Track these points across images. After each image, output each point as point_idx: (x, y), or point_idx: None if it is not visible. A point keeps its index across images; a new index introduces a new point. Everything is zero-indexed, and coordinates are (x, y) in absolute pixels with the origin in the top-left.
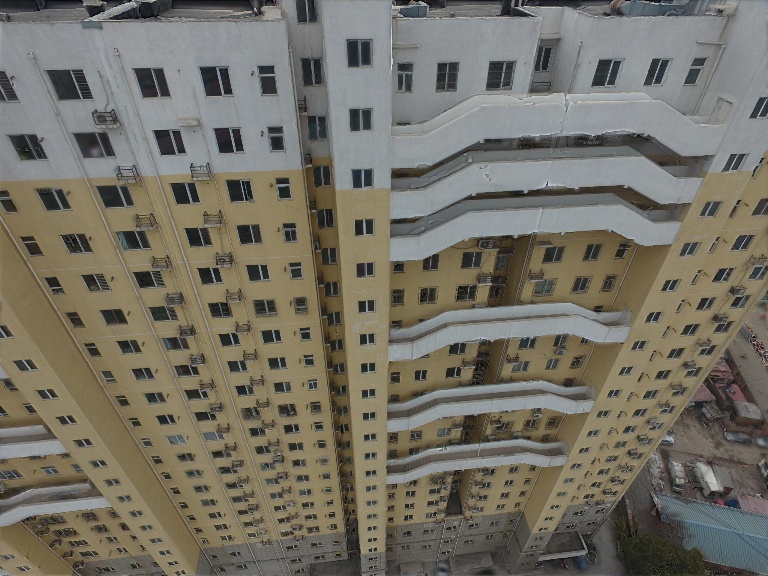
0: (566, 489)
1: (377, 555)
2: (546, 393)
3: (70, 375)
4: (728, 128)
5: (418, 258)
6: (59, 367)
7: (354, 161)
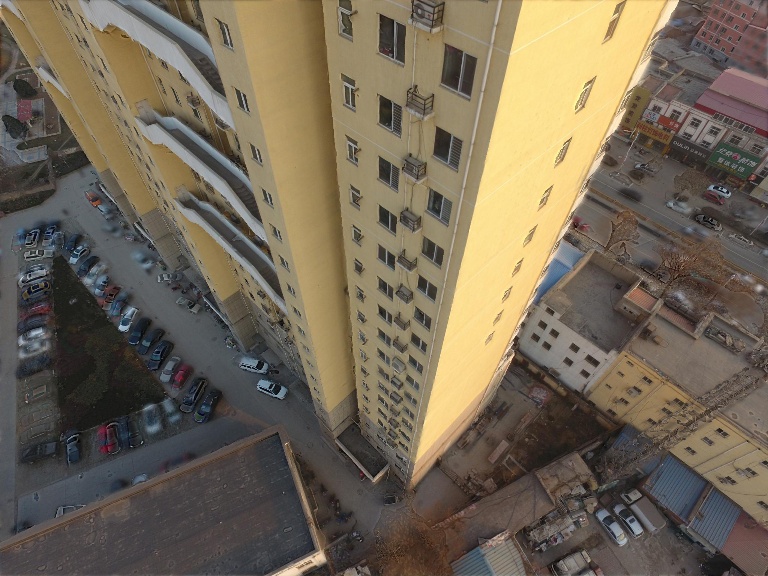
0: (309, 359)
1: (220, 301)
2: (223, 178)
3: None
4: None
5: None
6: None
7: None
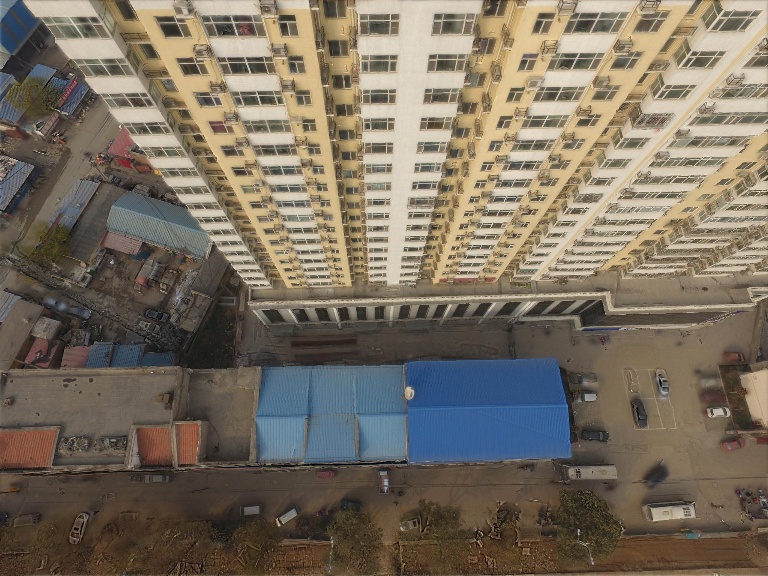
0: None
1: None
2: None
3: None
4: None
5: None
6: None
7: None
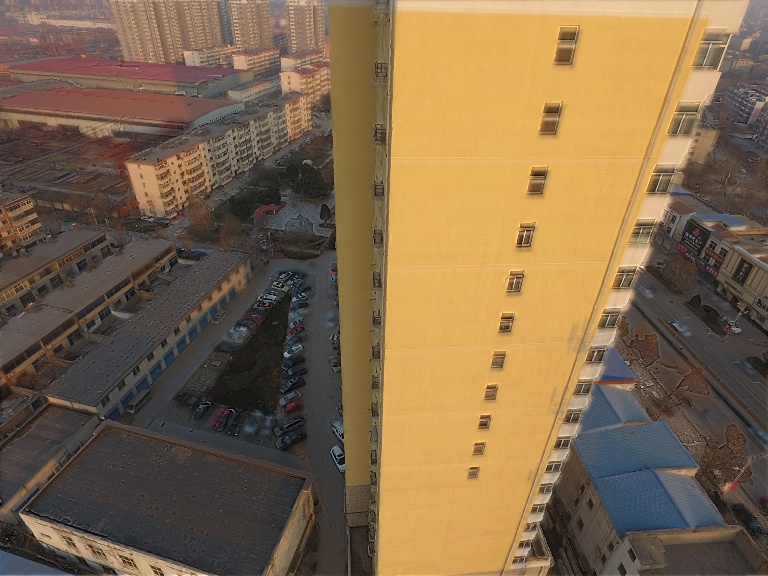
0: None
1: None
2: None
3: None
4: None
5: None
6: None
7: None
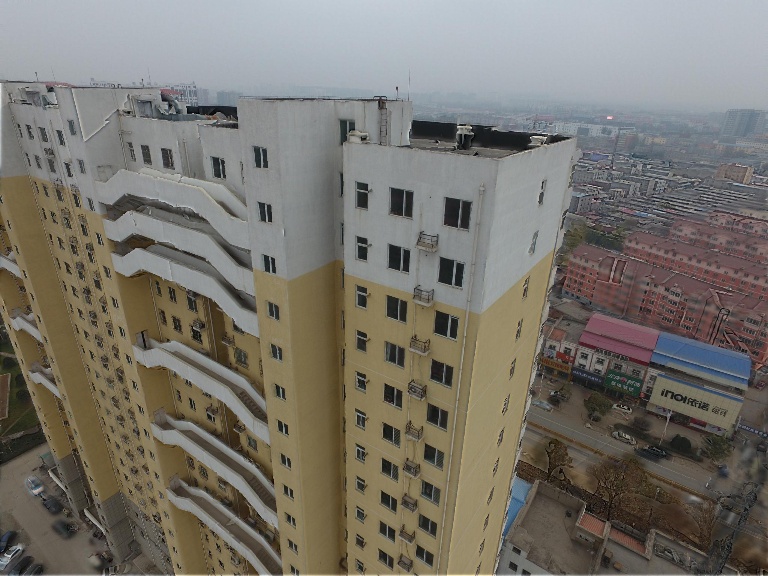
0: None
1: None
2: (240, 474)
3: (44, 292)
4: (248, 226)
5: (126, 275)
6: (37, 283)
7: (85, 192)
